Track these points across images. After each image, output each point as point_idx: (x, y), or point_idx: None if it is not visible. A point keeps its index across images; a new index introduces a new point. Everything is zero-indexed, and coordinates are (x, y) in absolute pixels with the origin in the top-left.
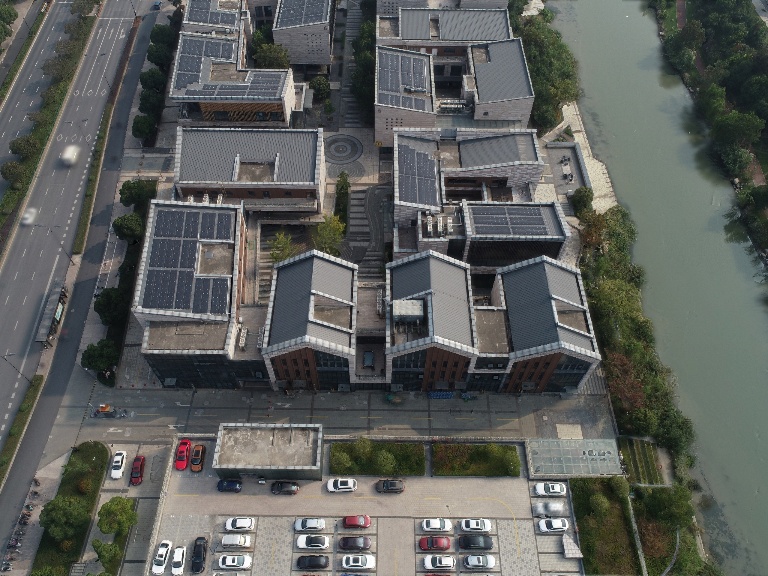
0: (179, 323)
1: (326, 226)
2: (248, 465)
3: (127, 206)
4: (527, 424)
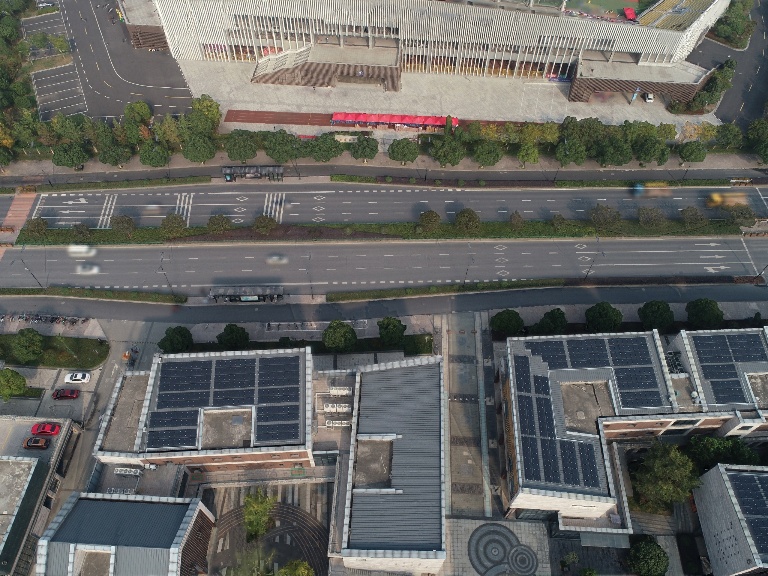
0: None
1: (293, 572)
2: None
3: (380, 329)
4: None
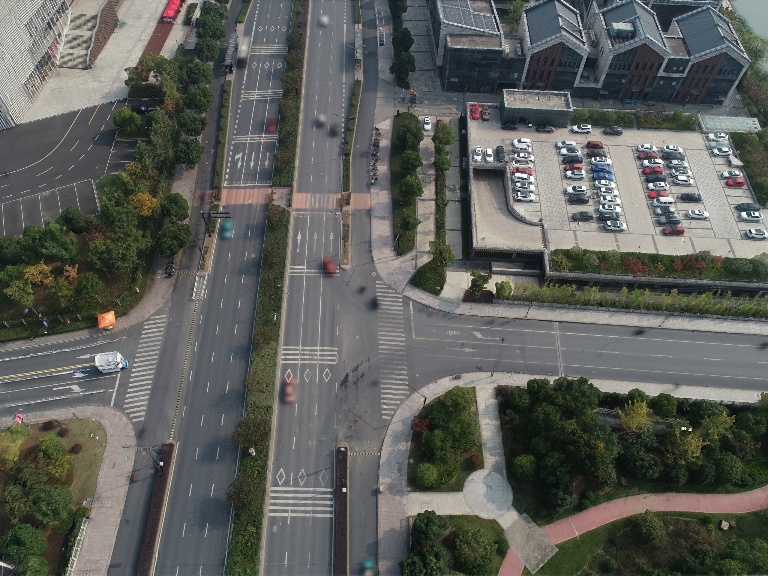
0: (467, 35)
1: None
2: (527, 107)
3: None
4: None
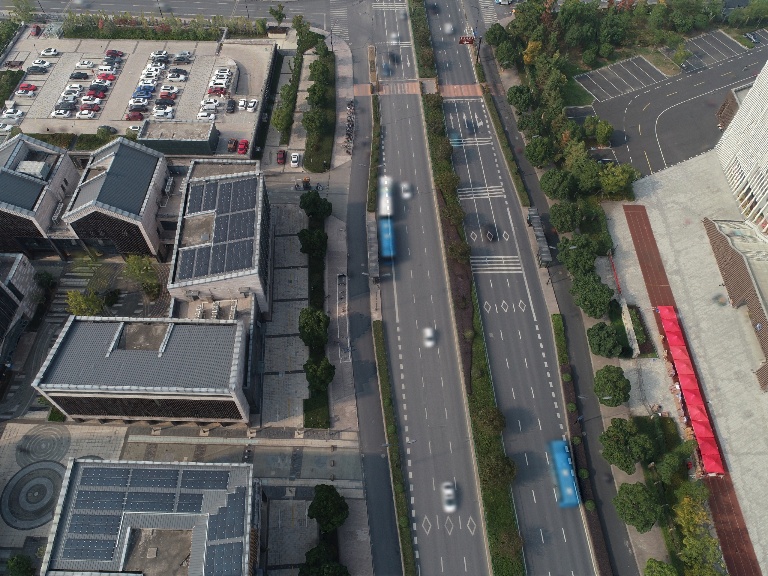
0: None
1: (86, 297)
2: (191, 122)
3: None
4: None
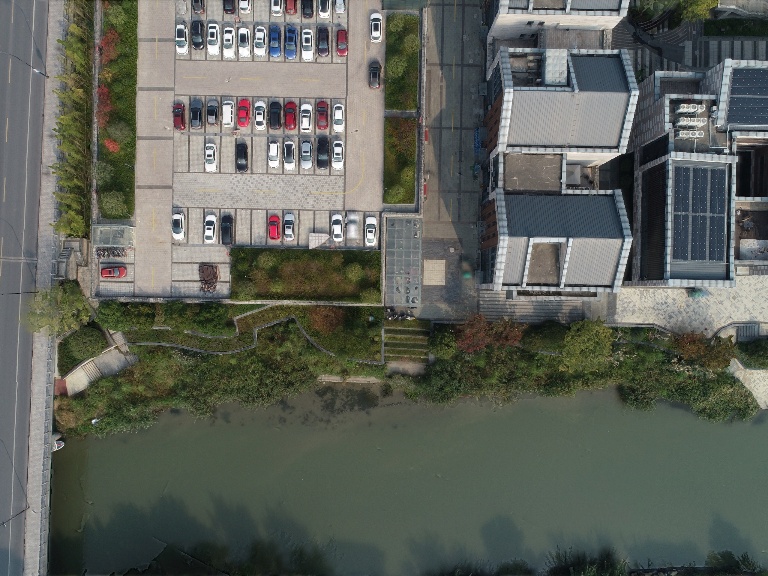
0: None
1: None
2: None
3: None
4: (446, 230)
